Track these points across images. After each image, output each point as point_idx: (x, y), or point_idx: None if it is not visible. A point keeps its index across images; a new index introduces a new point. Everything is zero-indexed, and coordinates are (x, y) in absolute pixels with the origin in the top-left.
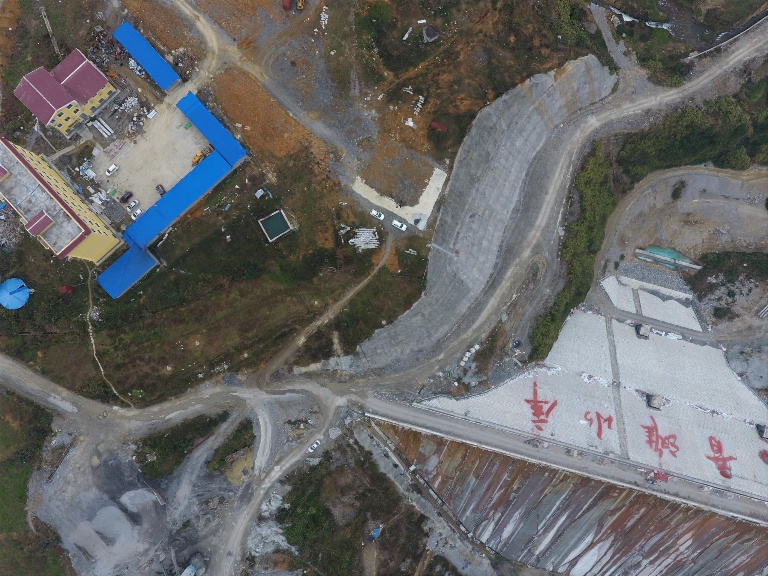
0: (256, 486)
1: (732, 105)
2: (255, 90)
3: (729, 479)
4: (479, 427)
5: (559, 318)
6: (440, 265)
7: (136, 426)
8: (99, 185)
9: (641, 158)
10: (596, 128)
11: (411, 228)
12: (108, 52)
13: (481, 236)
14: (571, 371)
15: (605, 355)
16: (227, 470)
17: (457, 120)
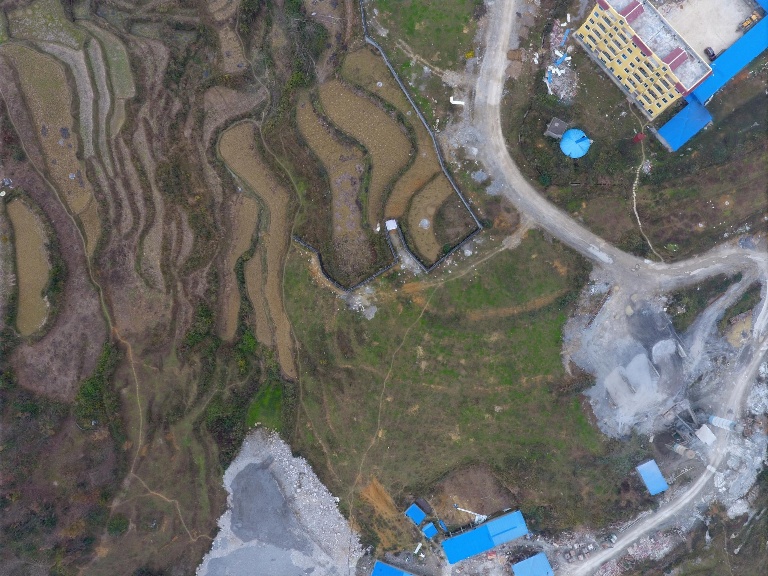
0: (755, 348)
1: None
2: None
3: None
4: None
5: None
6: None
7: (665, 280)
8: None
9: None
10: None
11: None
12: None
13: None
14: None
15: None
16: (727, 332)
17: None
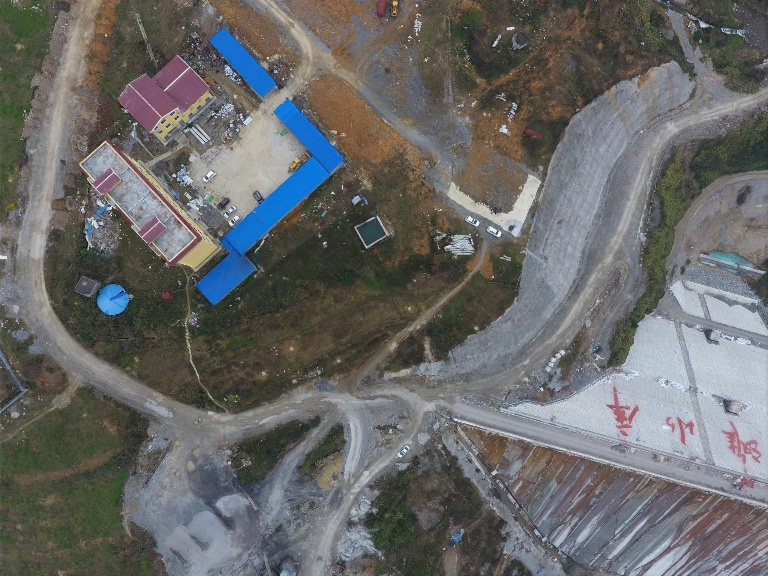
0: (346, 491)
1: None
2: (350, 97)
3: None
4: (566, 432)
5: None
6: (531, 271)
7: (231, 431)
8: (196, 191)
9: (714, 164)
10: (675, 134)
11: (505, 235)
12: (204, 59)
13: (567, 242)
14: (648, 376)
15: (679, 360)
16: (317, 475)
17: (551, 127)
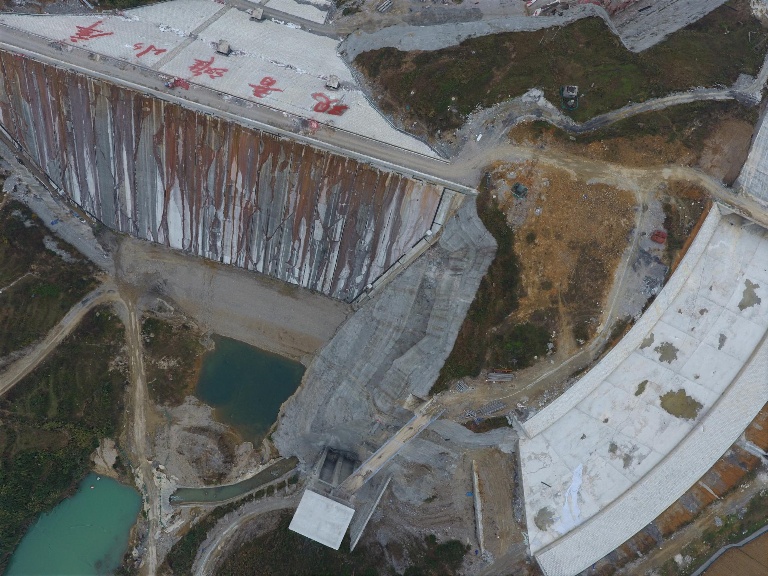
0: None
1: None
2: None
3: (259, 98)
4: (4, 29)
5: None
6: None
7: None
8: None
9: None
10: None
11: None
12: None
13: None
14: (149, 22)
15: (199, 21)
16: None
17: None
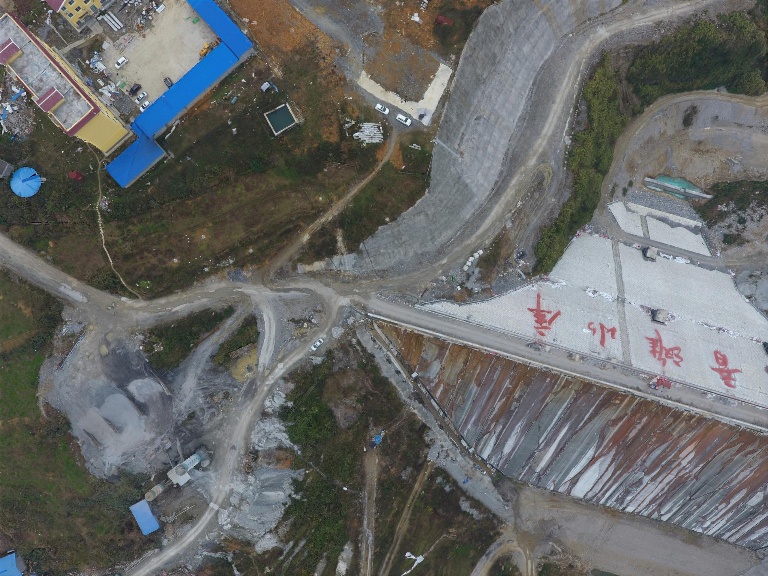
0: (260, 382)
1: (747, 20)
2: None
3: (733, 388)
4: (481, 330)
5: (564, 234)
6: (444, 164)
7: (143, 317)
8: (109, 78)
9: (652, 76)
10: (606, 39)
11: (416, 123)
12: None
13: (486, 141)
14: (575, 286)
15: (610, 273)
16: (232, 366)
17: (463, 15)
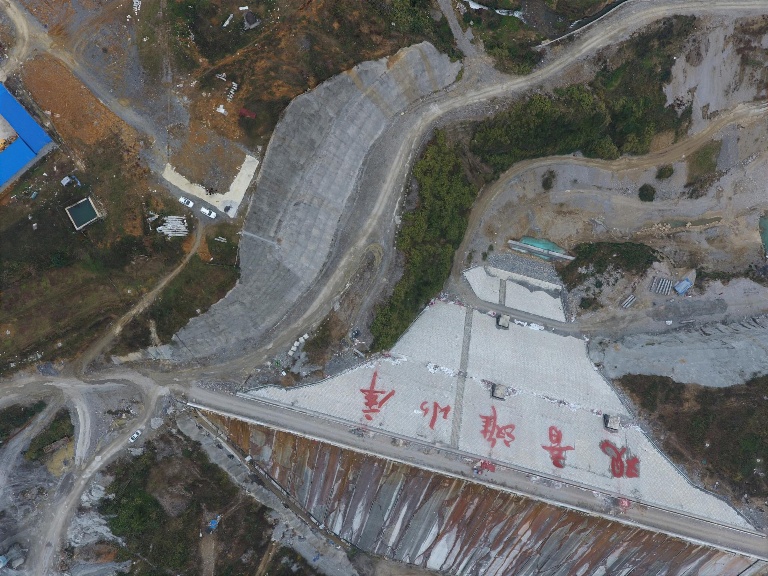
0: (76, 476)
1: (585, 93)
2: (65, 77)
3: (561, 469)
4: (304, 417)
5: (408, 308)
6: (257, 253)
7: None
8: None
9: (496, 147)
10: (438, 116)
11: (221, 216)
12: None
13: (309, 224)
14: (417, 361)
15: (457, 345)
16: (47, 460)
17: (269, 107)
